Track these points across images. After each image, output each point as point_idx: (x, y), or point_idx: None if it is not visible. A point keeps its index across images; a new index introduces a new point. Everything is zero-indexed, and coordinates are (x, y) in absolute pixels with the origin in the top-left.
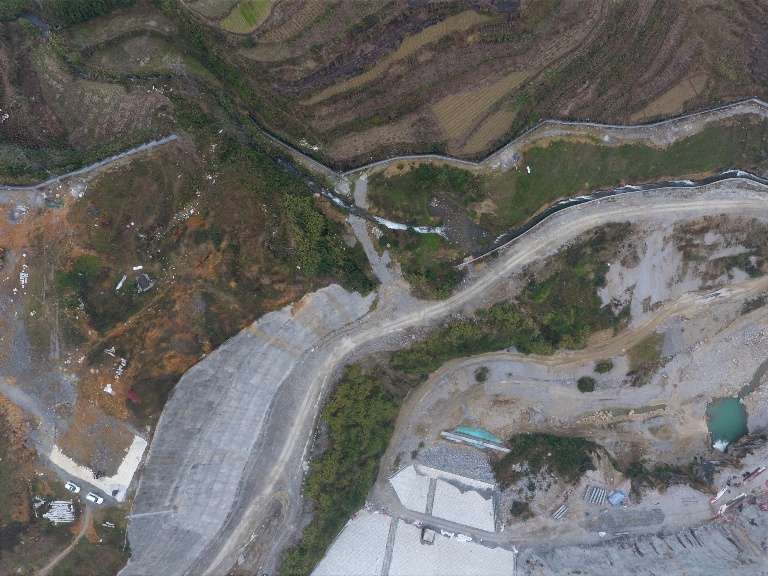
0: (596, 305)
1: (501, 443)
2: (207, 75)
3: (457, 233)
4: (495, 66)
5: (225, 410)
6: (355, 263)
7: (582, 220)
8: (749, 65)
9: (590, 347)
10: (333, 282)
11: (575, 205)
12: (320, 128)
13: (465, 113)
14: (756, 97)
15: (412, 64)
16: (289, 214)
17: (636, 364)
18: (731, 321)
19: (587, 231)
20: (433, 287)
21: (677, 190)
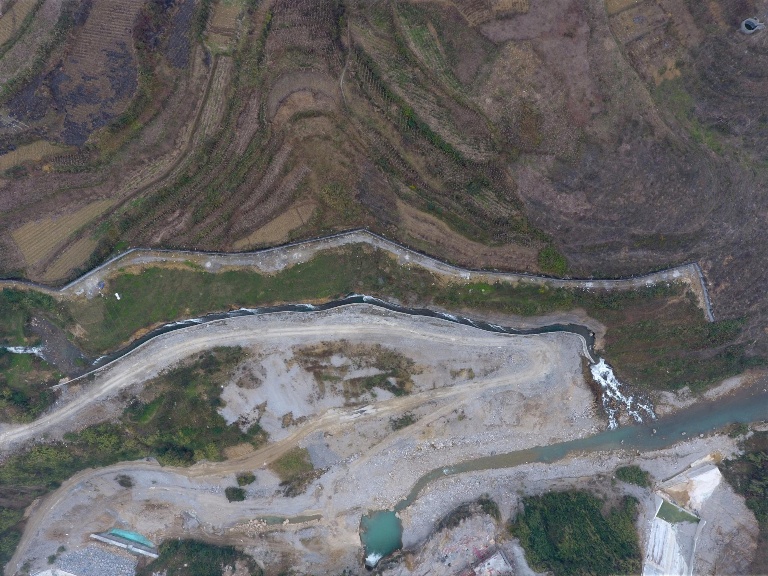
0: (217, 424)
1: (154, 547)
2: None
3: (55, 354)
4: (74, 195)
5: None
6: None
7: (188, 344)
8: (358, 196)
9: (232, 459)
10: None
11: (180, 329)
12: None
13: (45, 240)
14: (368, 227)
15: None
16: None
17: (287, 475)
18: (383, 436)
19: (192, 355)
20: (16, 410)
21: (294, 314)
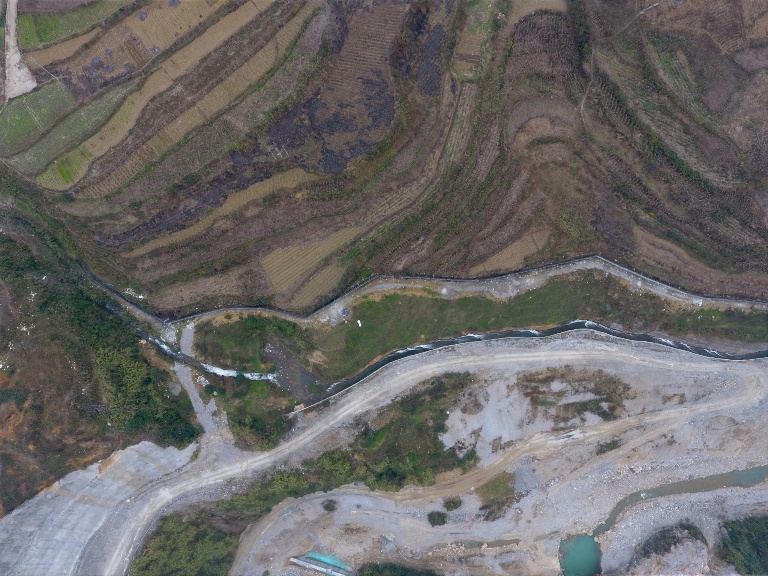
0: (437, 450)
1: (351, 571)
2: (37, 217)
3: (289, 380)
4: (324, 222)
5: (24, 568)
6: (178, 412)
7: (419, 370)
8: (593, 222)
9: (439, 484)
10: (144, 439)
11: (412, 355)
12: (143, 279)
13: (293, 267)
14: (600, 253)
15: (237, 220)
16: (100, 371)
17: (489, 499)
18: (586, 460)
19: (423, 381)
20: (258, 438)
21: (520, 340)
